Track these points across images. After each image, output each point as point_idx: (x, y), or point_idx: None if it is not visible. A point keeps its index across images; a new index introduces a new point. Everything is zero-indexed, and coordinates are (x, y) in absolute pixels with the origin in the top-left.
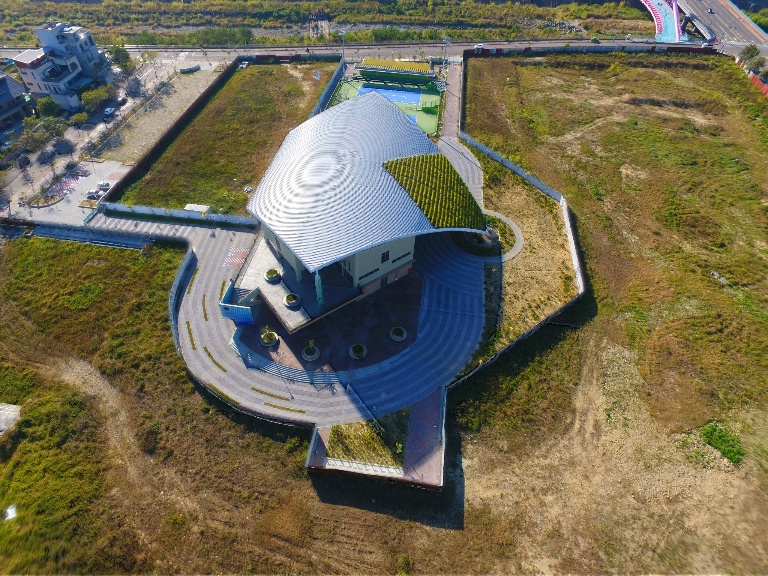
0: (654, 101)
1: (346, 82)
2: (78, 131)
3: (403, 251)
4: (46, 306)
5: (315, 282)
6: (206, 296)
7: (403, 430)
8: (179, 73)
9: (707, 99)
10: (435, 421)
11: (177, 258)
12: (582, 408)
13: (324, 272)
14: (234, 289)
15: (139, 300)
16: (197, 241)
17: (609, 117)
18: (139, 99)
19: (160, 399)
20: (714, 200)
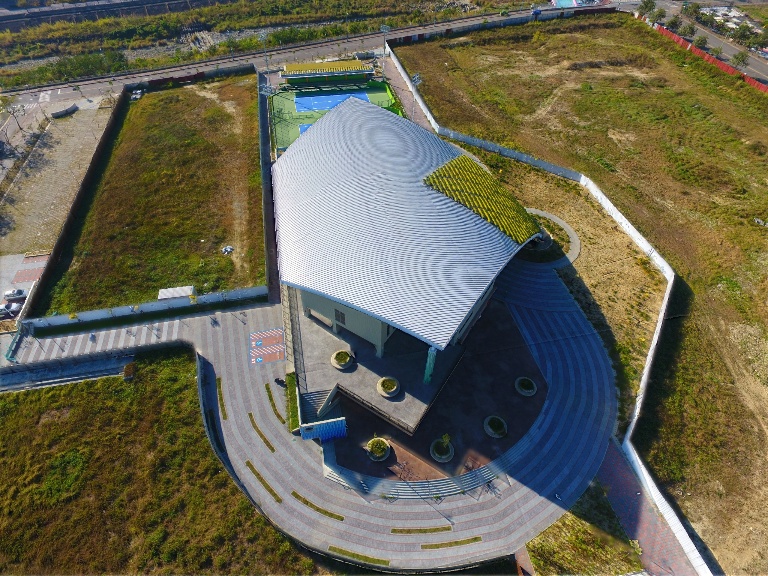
0: (592, 64)
1: (275, 95)
2: None
3: None
4: (3, 515)
5: (429, 357)
6: (253, 414)
7: (609, 514)
8: (51, 119)
9: (635, 54)
10: (635, 486)
11: (182, 371)
12: (757, 408)
13: (404, 335)
14: (302, 396)
15: (159, 454)
16: (197, 338)
17: (563, 86)
18: (9, 162)
19: None
20: (706, 148)
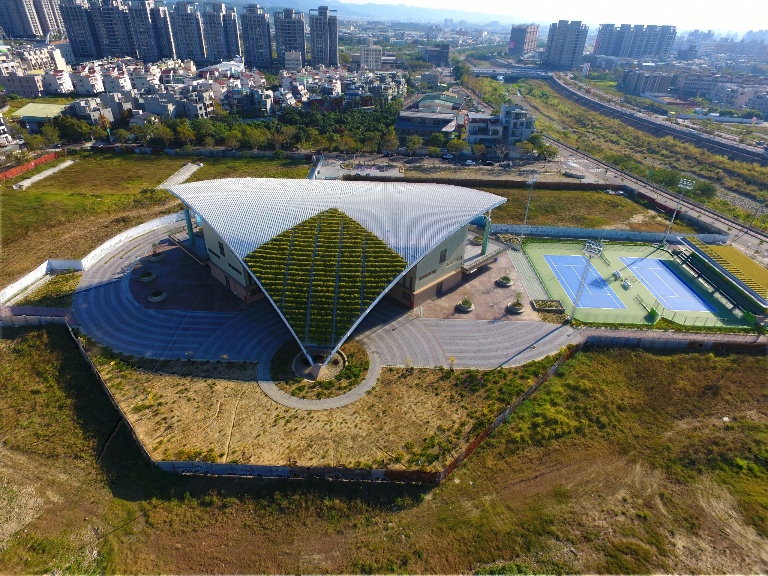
0: None
1: (657, 248)
2: (436, 161)
3: (235, 263)
4: None
5: None
6: None
7: (50, 305)
8: (561, 173)
9: None
10: None
11: None
12: None
13: None
14: None
15: None
16: None
17: None
18: (499, 168)
19: (151, 219)
20: None
